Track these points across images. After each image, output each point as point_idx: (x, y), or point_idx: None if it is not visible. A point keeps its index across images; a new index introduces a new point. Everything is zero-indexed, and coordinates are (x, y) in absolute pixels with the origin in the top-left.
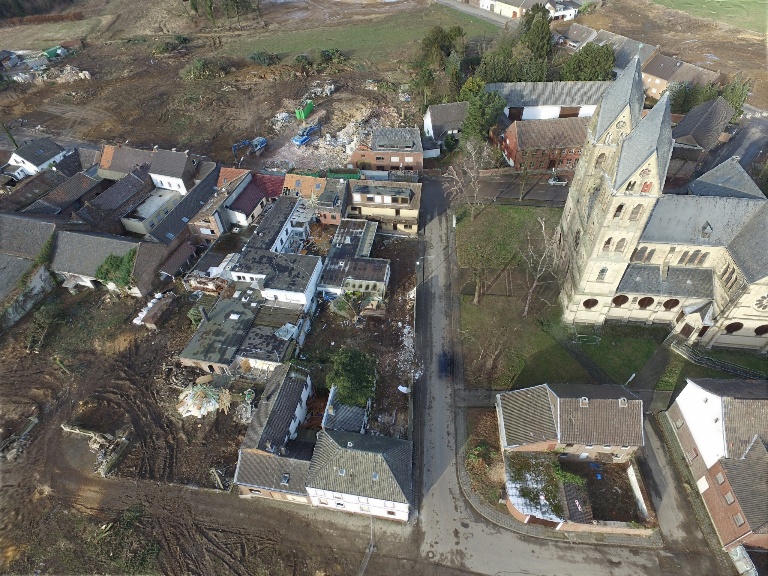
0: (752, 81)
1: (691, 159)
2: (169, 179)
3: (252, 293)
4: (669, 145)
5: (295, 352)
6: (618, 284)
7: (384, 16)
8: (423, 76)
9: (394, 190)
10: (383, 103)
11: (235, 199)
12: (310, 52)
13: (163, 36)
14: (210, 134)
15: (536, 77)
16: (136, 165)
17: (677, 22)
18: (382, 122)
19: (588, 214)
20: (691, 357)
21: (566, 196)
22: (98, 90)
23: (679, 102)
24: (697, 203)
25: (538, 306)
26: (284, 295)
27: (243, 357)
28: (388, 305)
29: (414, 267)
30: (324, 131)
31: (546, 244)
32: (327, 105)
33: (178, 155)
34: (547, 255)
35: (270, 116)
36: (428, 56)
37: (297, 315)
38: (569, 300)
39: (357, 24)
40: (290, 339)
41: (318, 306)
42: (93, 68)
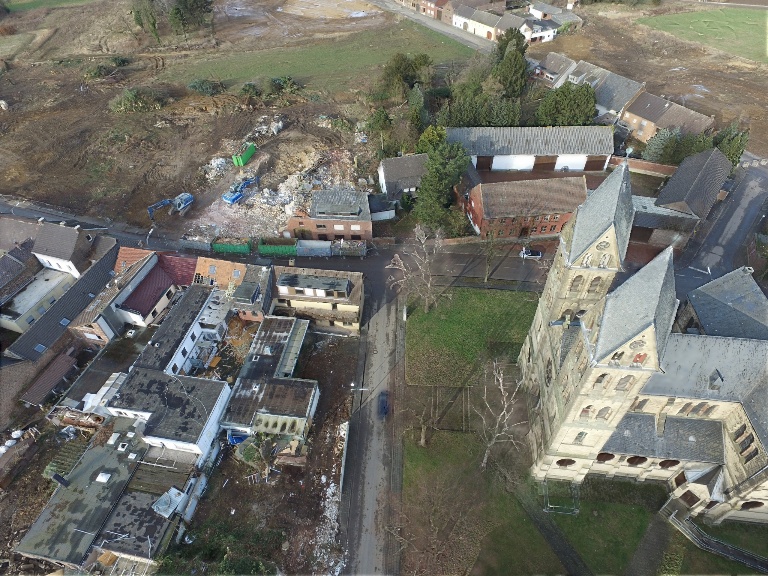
0: (746, 119)
1: (685, 230)
2: (56, 260)
3: (133, 436)
4: (671, 308)
5: (176, 536)
6: (601, 447)
7: (348, 34)
8: (378, 119)
9: (328, 281)
10: (336, 145)
11: (132, 292)
12: (258, 81)
13: (101, 56)
14: (130, 185)
15: (507, 120)
16: (15, 243)
17: (663, 46)
18: (332, 171)
19: (561, 355)
20: (696, 540)
21: (540, 275)
22: (12, 125)
23: (669, 152)
24: (703, 345)
25: (501, 449)
26: (172, 444)
27: (103, 549)
28: (311, 447)
29: (350, 384)
30: (265, 181)
31: (514, 350)
32: (272, 147)
33: (67, 231)
34: (515, 367)
35: (204, 161)
36: (389, 88)
37: (187, 474)
38: (538, 457)
39: (318, 44)
40: (171, 516)
41: (221, 450)
42: (12, 96)
